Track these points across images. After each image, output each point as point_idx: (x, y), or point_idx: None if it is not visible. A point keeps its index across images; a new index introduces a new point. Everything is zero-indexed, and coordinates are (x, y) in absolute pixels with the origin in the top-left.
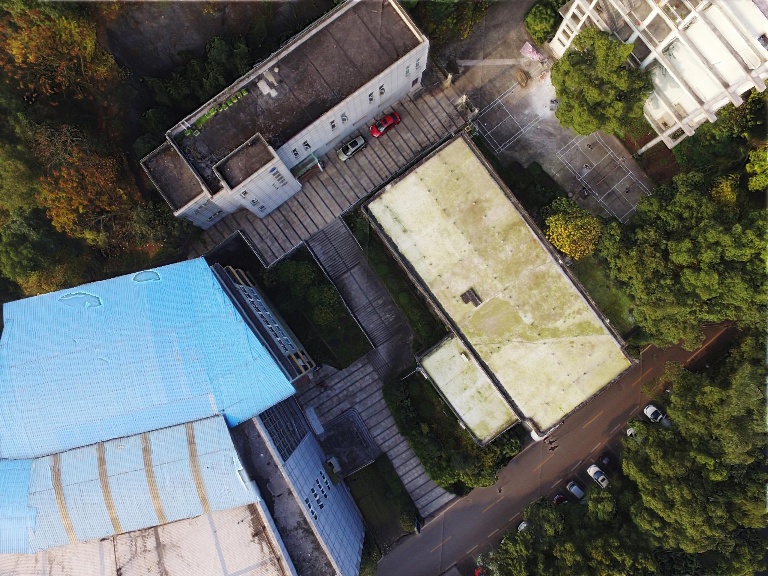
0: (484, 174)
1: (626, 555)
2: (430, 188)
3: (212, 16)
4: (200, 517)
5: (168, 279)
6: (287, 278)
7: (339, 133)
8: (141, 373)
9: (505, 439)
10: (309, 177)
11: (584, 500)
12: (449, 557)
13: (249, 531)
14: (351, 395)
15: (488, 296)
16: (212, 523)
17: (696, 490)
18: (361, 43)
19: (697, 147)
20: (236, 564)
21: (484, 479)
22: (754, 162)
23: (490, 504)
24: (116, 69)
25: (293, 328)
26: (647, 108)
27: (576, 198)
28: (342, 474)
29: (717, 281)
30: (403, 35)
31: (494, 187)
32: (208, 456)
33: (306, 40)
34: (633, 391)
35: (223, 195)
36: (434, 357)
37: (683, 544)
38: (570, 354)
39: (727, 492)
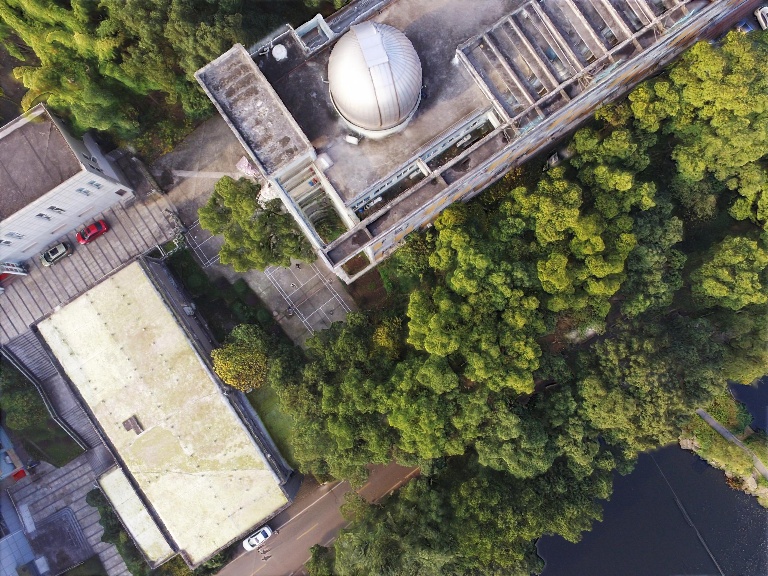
0: (157, 300)
1: None
2: (100, 311)
3: None
4: None
5: None
6: None
7: None
8: None
9: None
10: (12, 280)
11: None
12: None
13: None
14: (67, 494)
15: (150, 424)
16: None
17: None
18: (26, 165)
19: None
20: None
21: None
22: None
23: None
24: None
25: None
26: None
27: (281, 317)
28: (50, 574)
29: (346, 435)
30: (69, 160)
31: (166, 314)
32: None
33: None
34: None
35: None
36: (112, 475)
37: None
38: (228, 488)
39: None
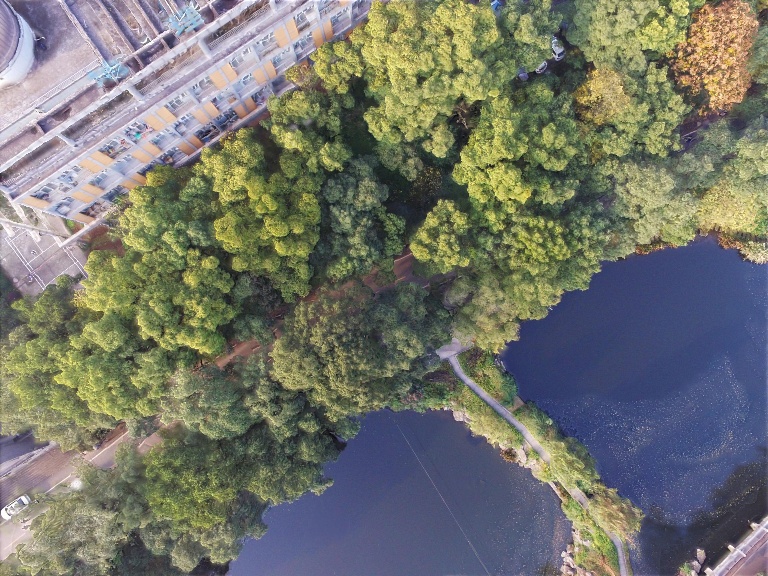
0: None
1: None
2: None
3: None
4: None
5: None
6: None
7: None
8: None
9: None
10: None
11: None
12: None
13: None
14: None
15: None
16: None
17: None
18: None
19: None
20: None
21: None
22: None
23: None
24: None
25: None
26: None
27: (21, 284)
28: None
29: (22, 393)
30: None
31: None
32: None
33: None
34: None
35: None
36: None
37: None
38: None
39: None
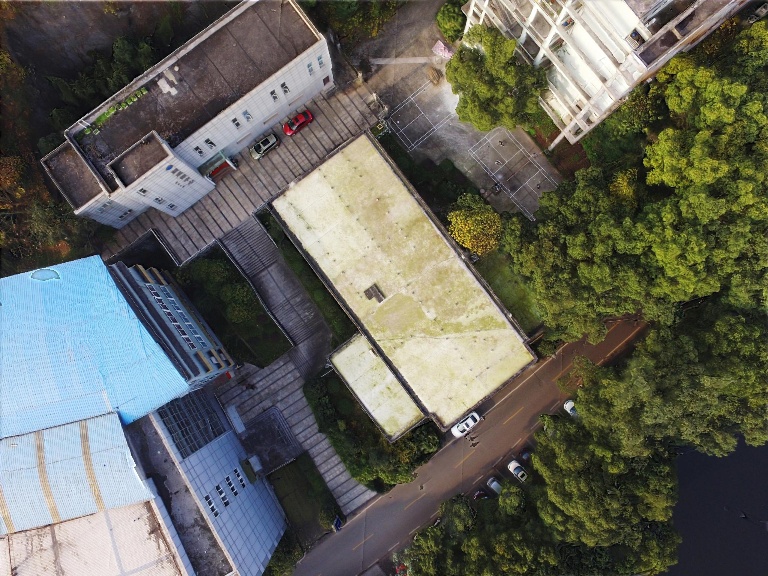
0: (387, 171)
1: (528, 549)
2: (333, 185)
3: (114, 16)
4: (95, 515)
5: (67, 277)
6: (199, 276)
7: (249, 131)
8: (33, 371)
9: (423, 435)
10: (223, 176)
11: (499, 495)
12: (371, 555)
13: (145, 529)
14: (273, 393)
15: (391, 292)
16: (108, 521)
17: (594, 483)
18: (260, 42)
19: (606, 143)
20: (132, 562)
21: (401, 476)
22: (650, 156)
23: (411, 501)
24: (16, 69)
25: (215, 327)
26: (556, 105)
27: (488, 194)
28: (263, 472)
29: (608, 274)
30: (302, 33)
31: (397, 183)
32: (105, 454)
33: (206, 39)
34: (553, 386)
35: (122, 193)
36: (344, 353)
37: (583, 537)
38: (473, 349)
39: (629, 485)
